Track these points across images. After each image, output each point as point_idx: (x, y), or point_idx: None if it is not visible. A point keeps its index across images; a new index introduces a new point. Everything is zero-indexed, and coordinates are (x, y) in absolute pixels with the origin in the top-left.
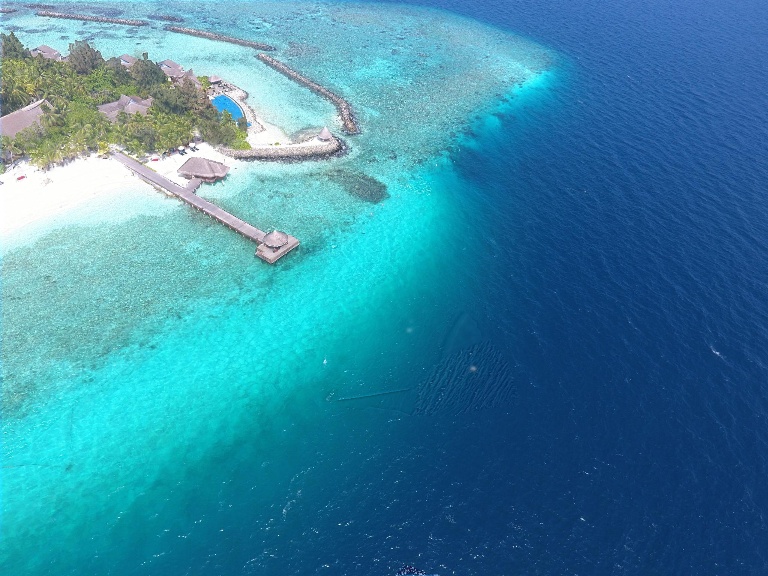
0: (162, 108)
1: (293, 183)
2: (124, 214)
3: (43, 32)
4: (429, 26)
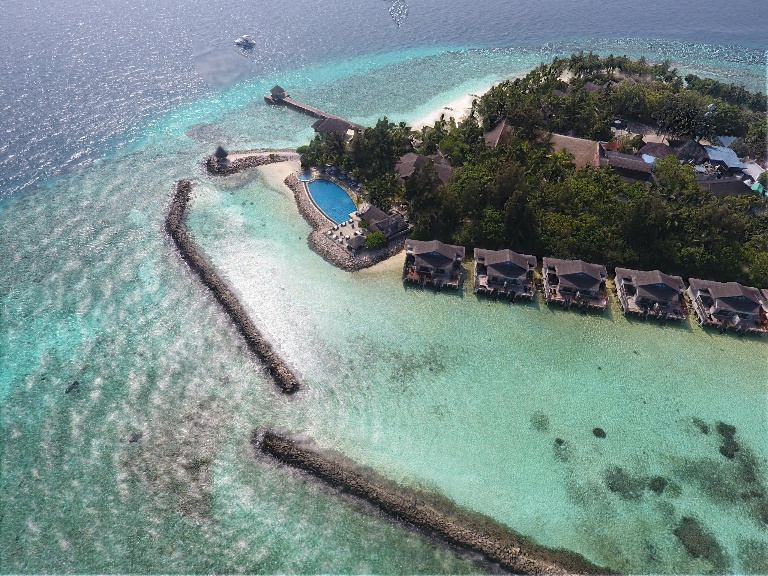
0: None
1: (263, 136)
2: (378, 118)
3: None
4: None
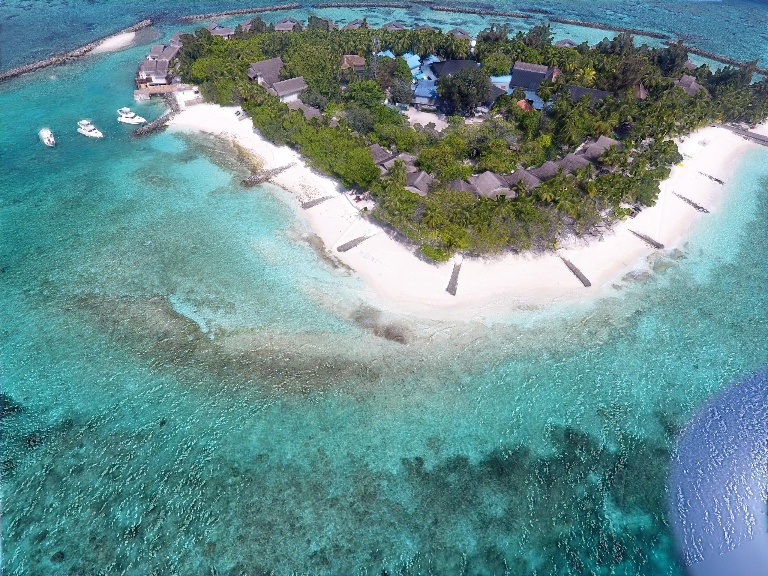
0: (738, 85)
1: None
2: None
3: (465, 24)
4: (755, 15)
